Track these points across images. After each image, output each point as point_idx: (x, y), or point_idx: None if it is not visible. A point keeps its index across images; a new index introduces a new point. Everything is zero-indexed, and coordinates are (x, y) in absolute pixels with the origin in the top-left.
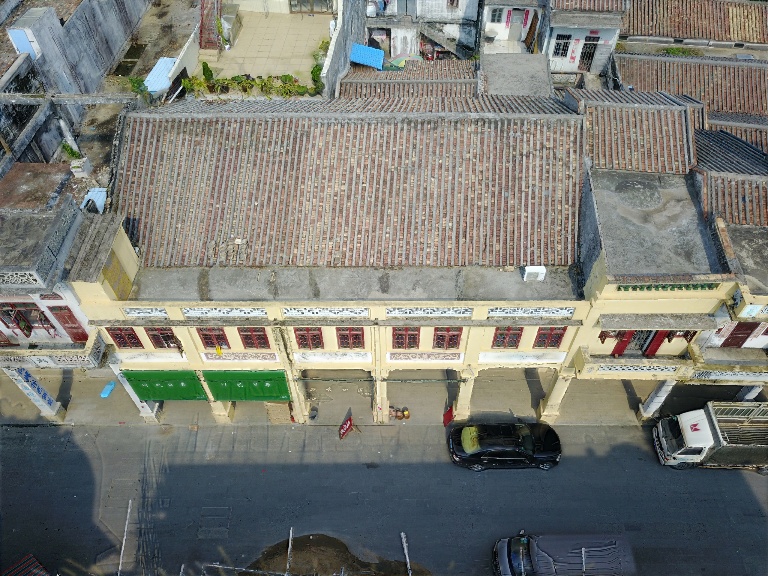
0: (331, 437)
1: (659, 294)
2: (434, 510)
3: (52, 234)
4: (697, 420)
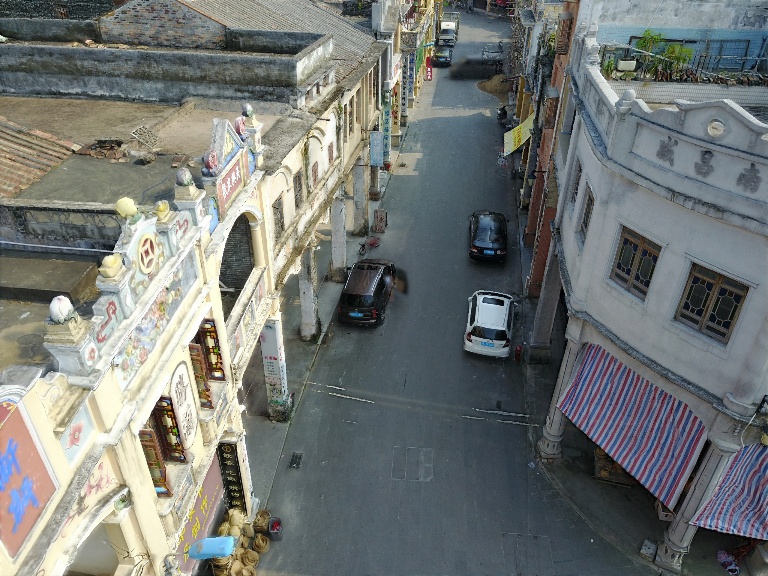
0: (430, 82)
1: None
2: None
3: None
4: (445, 24)
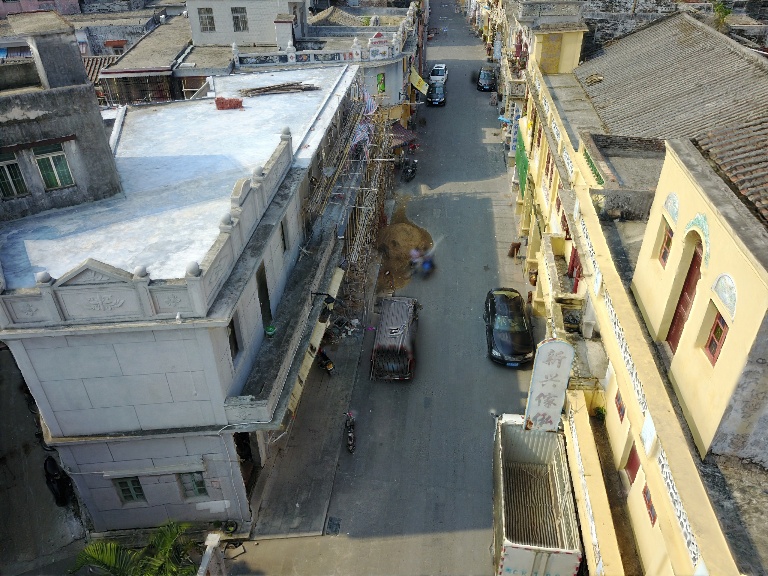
0: None
1: (588, 174)
2: (449, 292)
3: (548, 1)
4: None
